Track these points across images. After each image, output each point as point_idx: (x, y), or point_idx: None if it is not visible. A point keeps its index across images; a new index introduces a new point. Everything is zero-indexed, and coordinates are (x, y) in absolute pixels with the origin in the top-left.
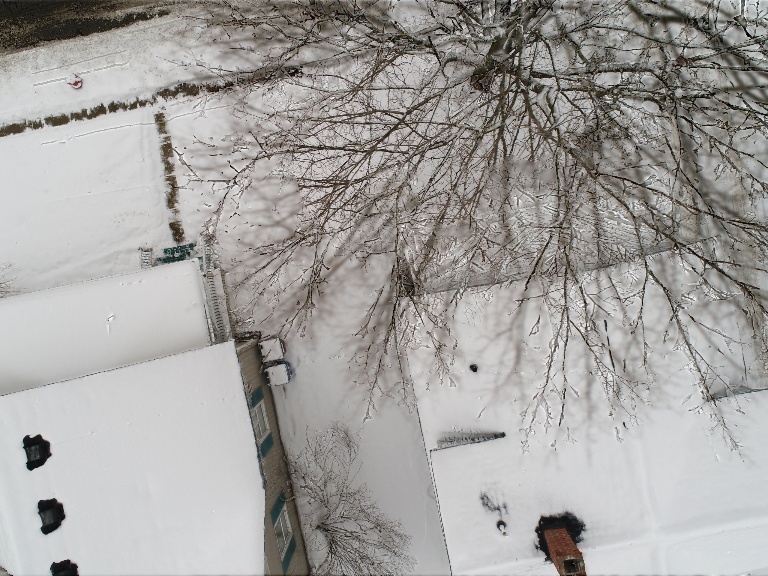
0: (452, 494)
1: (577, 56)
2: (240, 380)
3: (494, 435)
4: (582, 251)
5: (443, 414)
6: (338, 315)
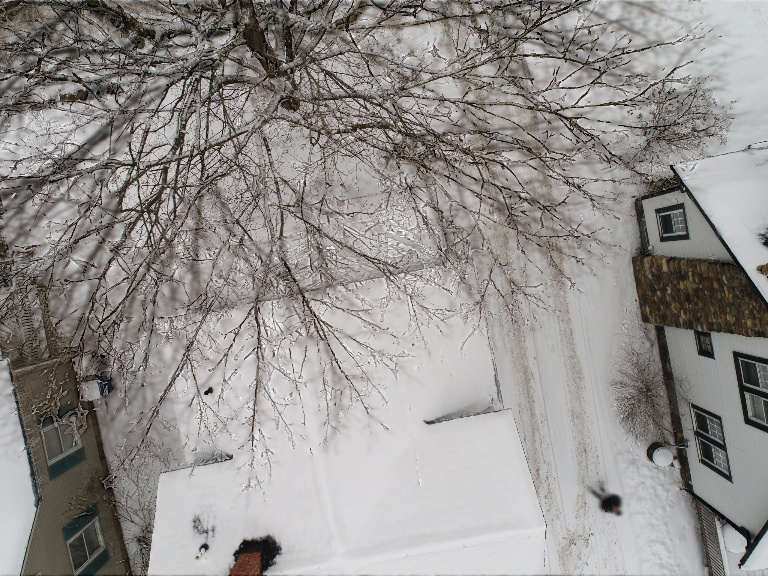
0: (166, 517)
1: None
2: (12, 399)
3: None
4: None
5: None
6: None
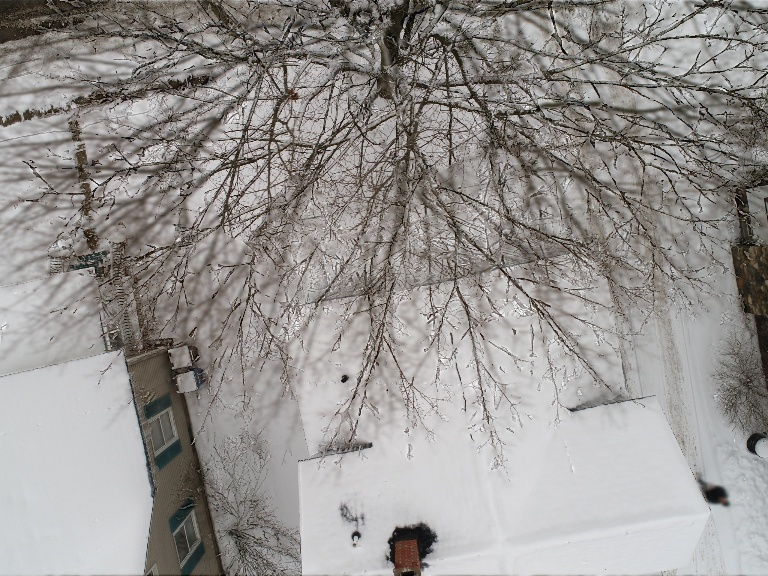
0: (312, 505)
1: (484, 64)
2: (129, 389)
3: (364, 445)
4: None
5: (321, 424)
6: None
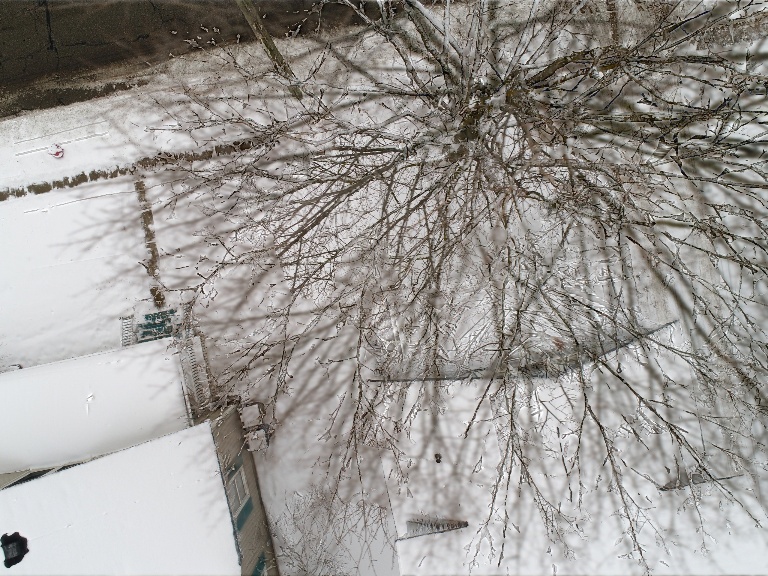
0: None
1: (546, 126)
2: (216, 460)
3: (458, 523)
4: (540, 348)
5: None
6: (316, 378)
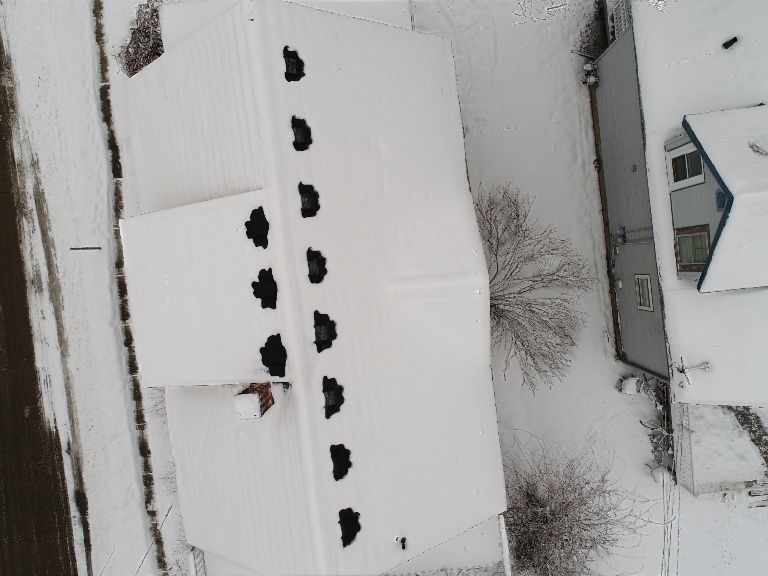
0: (719, 141)
1: None
2: (455, 79)
3: None
4: None
5: (679, 106)
6: (511, 86)
